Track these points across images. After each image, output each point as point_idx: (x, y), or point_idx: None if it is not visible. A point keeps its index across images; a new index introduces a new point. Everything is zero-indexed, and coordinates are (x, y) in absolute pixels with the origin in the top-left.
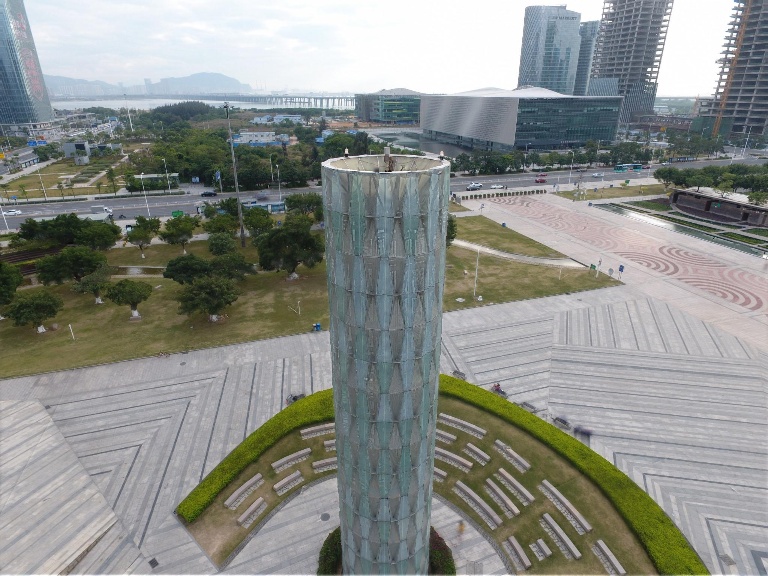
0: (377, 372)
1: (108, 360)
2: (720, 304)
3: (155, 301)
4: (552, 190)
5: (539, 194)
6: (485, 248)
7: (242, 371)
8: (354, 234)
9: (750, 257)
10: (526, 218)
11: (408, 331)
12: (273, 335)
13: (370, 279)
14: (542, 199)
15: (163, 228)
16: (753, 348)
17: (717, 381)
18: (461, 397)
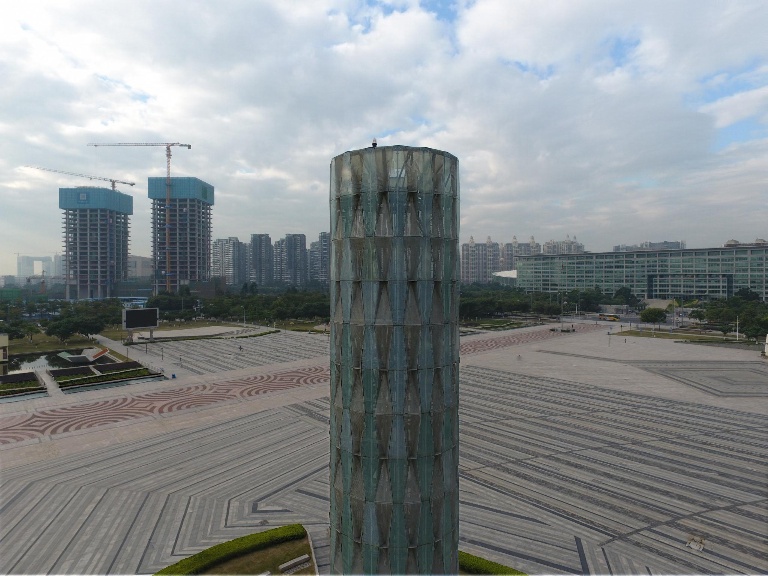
0: None
1: None
2: None
3: None
4: None
5: None
6: None
7: None
8: None
9: None
10: None
11: None
12: None
13: None
14: None
15: None
16: None
17: (25, 503)
18: None
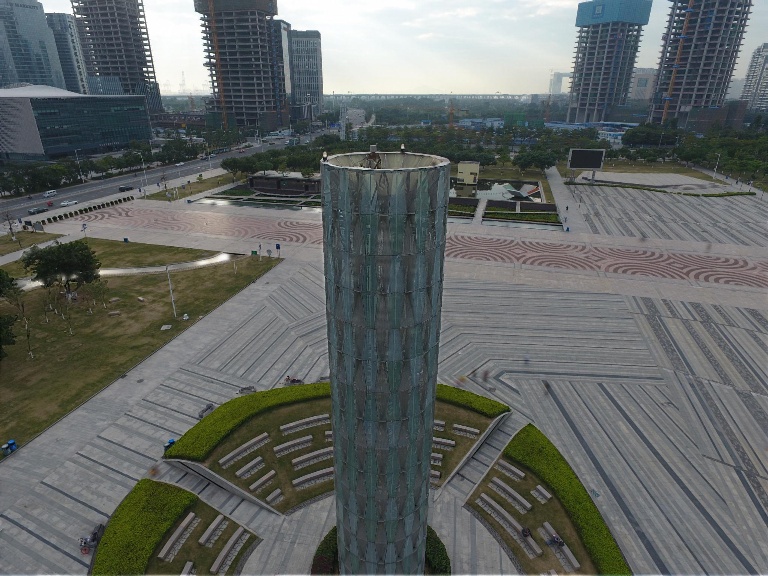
0: None
1: None
2: None
3: None
4: (139, 195)
5: (128, 202)
6: (130, 269)
7: None
8: (417, 232)
9: None
10: (142, 228)
11: None
12: None
13: (425, 272)
14: (137, 206)
15: None
16: None
17: None
18: (283, 402)
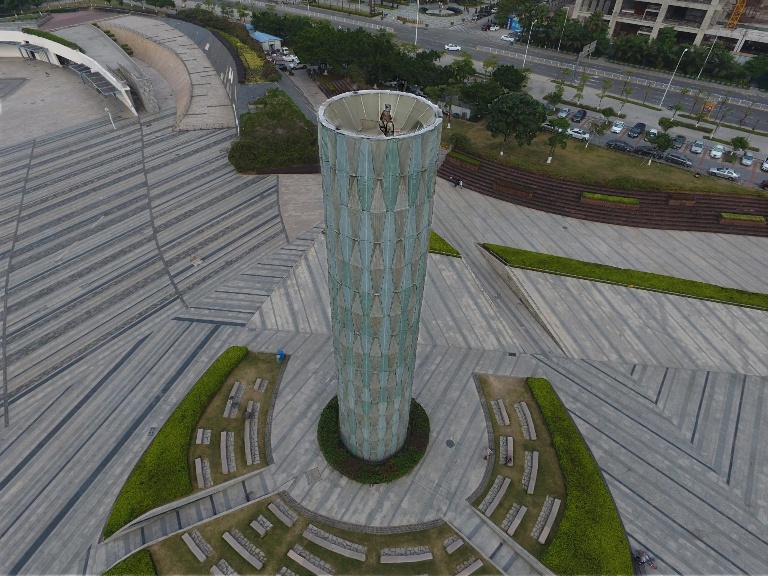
0: None
1: None
2: None
3: None
4: None
5: None
6: None
7: None
8: None
9: None
10: None
11: None
12: None
13: None
14: None
15: None
16: None
17: None
18: None
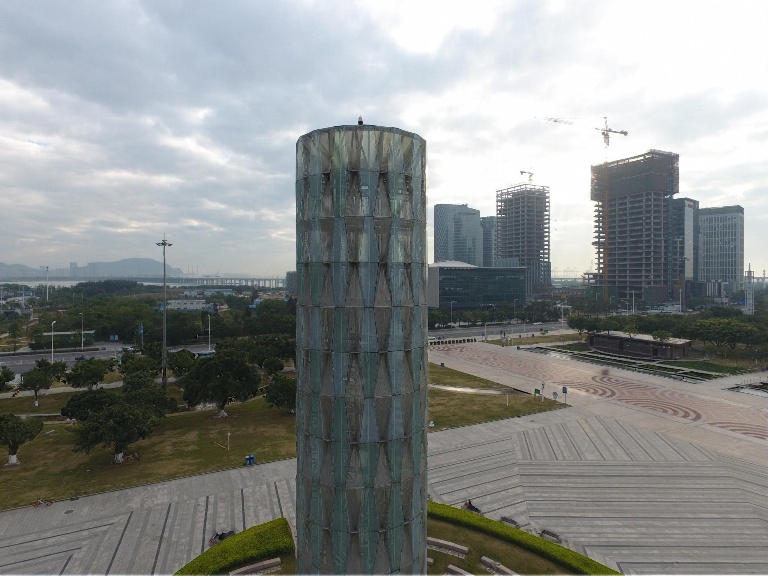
0: (360, 366)
1: None
2: (664, 417)
3: (43, 446)
4: (481, 339)
5: (470, 342)
6: None
7: (151, 514)
8: (335, 194)
9: (673, 381)
10: (462, 359)
11: (395, 312)
12: (195, 472)
13: (352, 245)
14: (474, 346)
15: None
16: (710, 451)
17: (692, 482)
18: (431, 512)
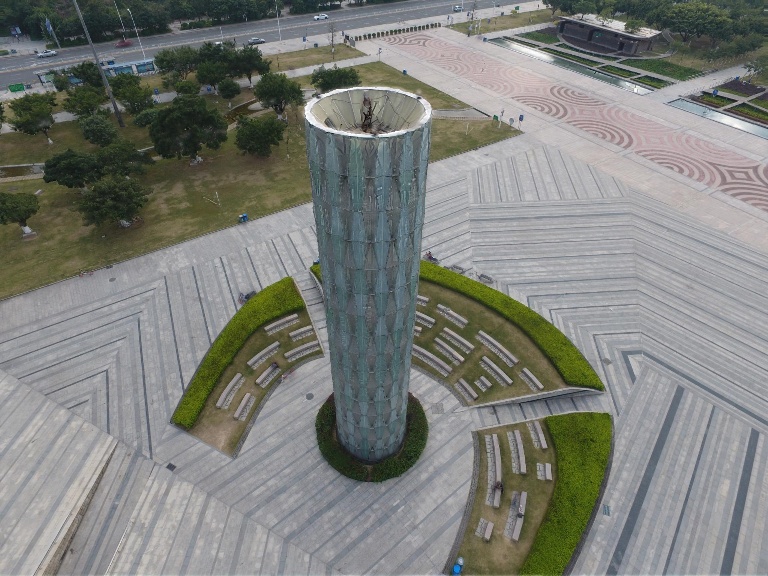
0: (375, 301)
1: (22, 289)
2: (601, 145)
3: (43, 211)
4: (446, 23)
5: (434, 28)
6: None
7: (181, 277)
8: (353, 193)
9: (624, 92)
10: (425, 62)
11: (401, 265)
12: (199, 233)
13: (368, 229)
14: (438, 35)
15: (8, 112)
16: (625, 186)
17: (599, 221)
18: None
